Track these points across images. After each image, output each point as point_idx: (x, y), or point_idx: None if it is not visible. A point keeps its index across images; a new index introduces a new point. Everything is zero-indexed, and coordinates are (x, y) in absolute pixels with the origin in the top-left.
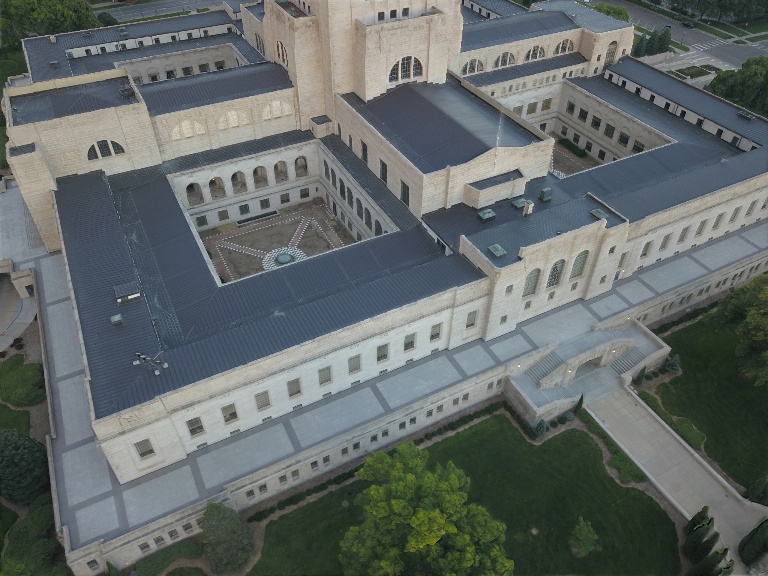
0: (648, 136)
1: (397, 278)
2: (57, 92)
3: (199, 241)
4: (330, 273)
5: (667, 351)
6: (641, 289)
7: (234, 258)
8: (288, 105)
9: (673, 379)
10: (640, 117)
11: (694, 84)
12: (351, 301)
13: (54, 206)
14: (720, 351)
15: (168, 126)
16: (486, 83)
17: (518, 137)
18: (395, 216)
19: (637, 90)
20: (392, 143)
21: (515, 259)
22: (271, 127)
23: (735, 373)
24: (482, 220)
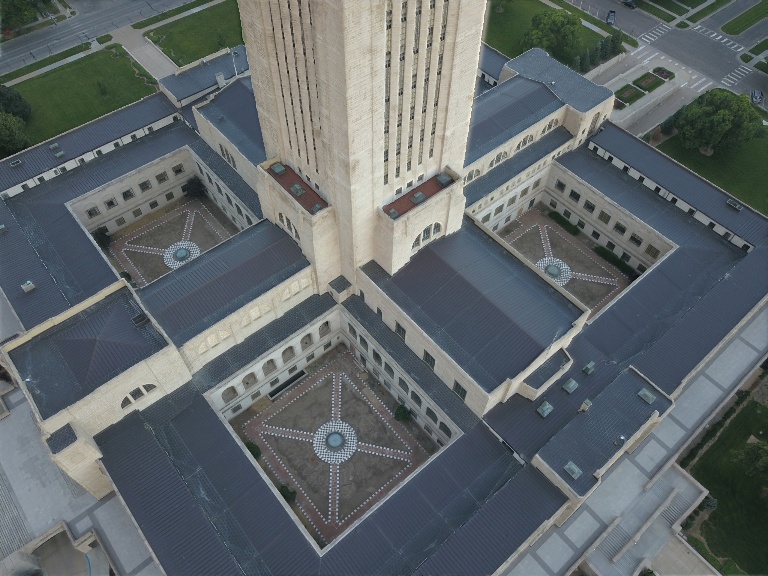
0: (647, 234)
1: (487, 514)
2: (57, 329)
3: (276, 492)
4: (417, 508)
5: (706, 495)
6: (673, 427)
7: (283, 448)
8: (305, 280)
9: (711, 515)
10: (637, 211)
11: (653, 102)
12: (457, 558)
13: (112, 486)
14: (741, 472)
15: (195, 347)
16: (485, 191)
17: (554, 307)
18: (453, 412)
19: (625, 168)
20: (437, 338)
21: (591, 478)
22: (290, 303)
23: (757, 495)
24: (542, 417)
